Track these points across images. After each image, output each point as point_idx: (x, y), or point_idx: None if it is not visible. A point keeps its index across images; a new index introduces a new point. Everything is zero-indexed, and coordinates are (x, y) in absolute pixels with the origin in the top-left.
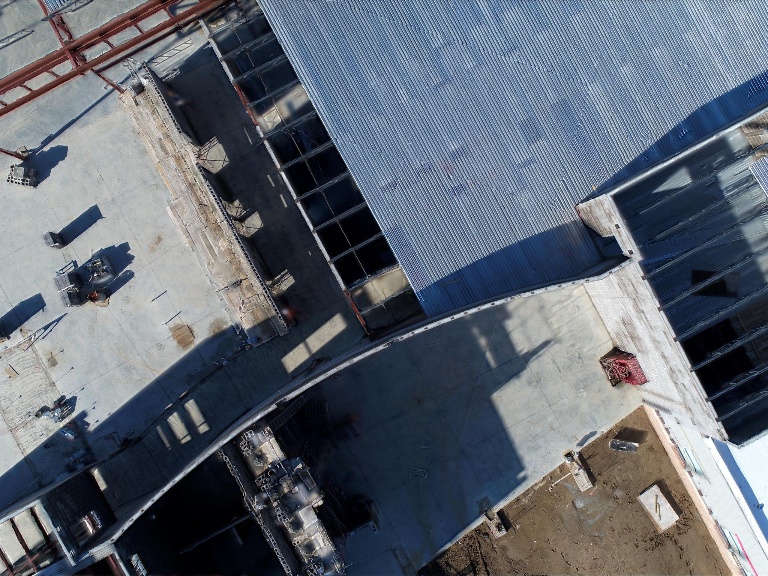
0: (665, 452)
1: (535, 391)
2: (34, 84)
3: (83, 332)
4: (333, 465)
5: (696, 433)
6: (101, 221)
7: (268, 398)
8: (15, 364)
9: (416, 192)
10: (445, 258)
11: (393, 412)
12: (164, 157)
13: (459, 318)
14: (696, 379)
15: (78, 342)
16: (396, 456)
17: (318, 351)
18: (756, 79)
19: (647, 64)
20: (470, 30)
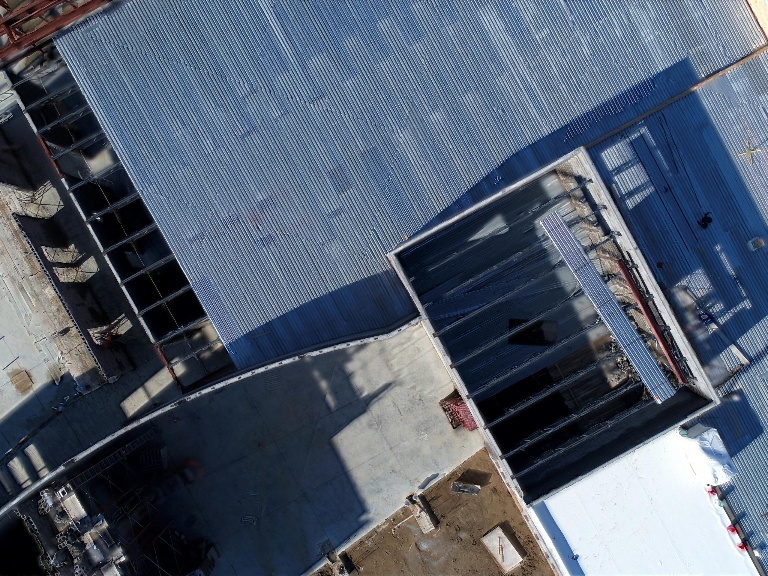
0: (509, 494)
1: (376, 434)
2: None
3: None
4: (174, 509)
5: (511, 484)
6: None
7: None
8: None
9: (224, 244)
10: (254, 310)
11: (233, 456)
12: None
13: (298, 361)
14: (490, 436)
15: None
16: (237, 499)
17: (156, 395)
18: (573, 124)
19: (460, 110)
20: (277, 78)
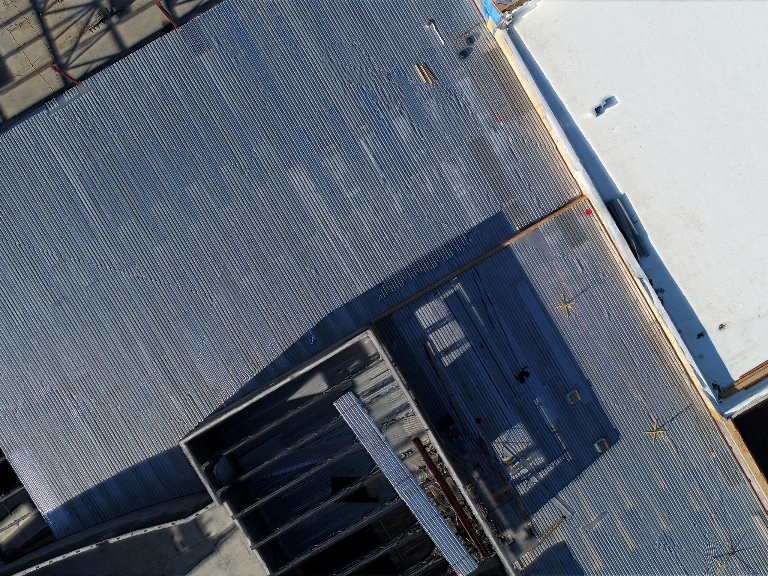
0: None
1: (225, 573)
2: None
3: None
4: None
5: None
6: None
7: None
8: None
9: (38, 414)
10: (71, 479)
11: None
12: None
13: None
14: None
15: None
16: None
17: (3, 542)
18: (387, 281)
19: (273, 272)
20: (86, 246)
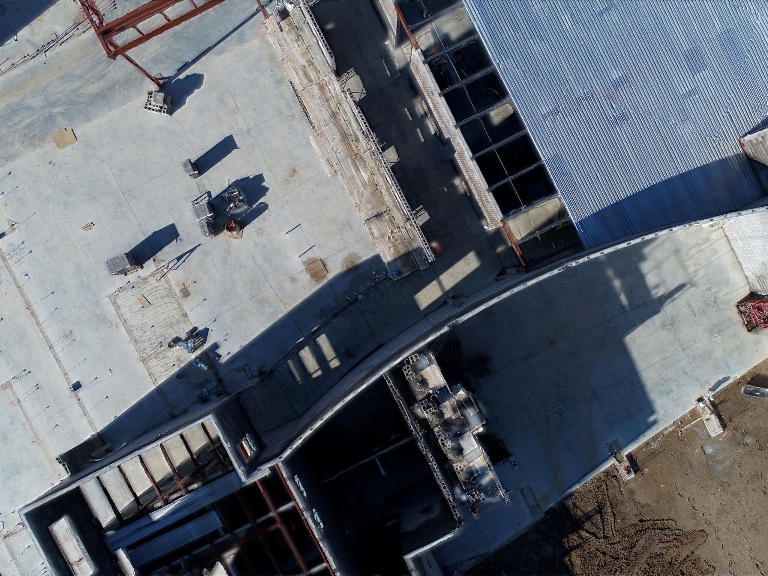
0: None
1: (669, 334)
2: (171, 10)
3: (216, 264)
4: None
5: None
6: (236, 152)
7: (409, 331)
8: (148, 294)
9: (578, 120)
10: (605, 189)
11: (525, 352)
12: (308, 85)
13: (595, 259)
14: None
15: (211, 273)
16: (526, 396)
17: (451, 288)
18: None
19: None
20: None
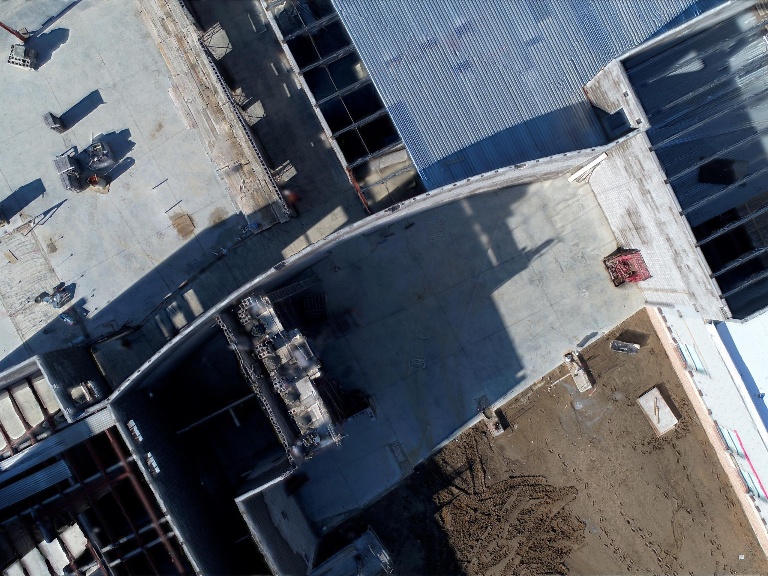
0: (666, 355)
1: (537, 290)
2: None
3: (83, 219)
4: (331, 359)
5: (699, 321)
6: (102, 107)
7: None
8: (14, 249)
9: (421, 68)
10: (449, 136)
11: (393, 307)
12: (166, 37)
13: (462, 214)
14: (701, 255)
15: (78, 229)
16: (395, 352)
17: None
18: None
19: None
20: None
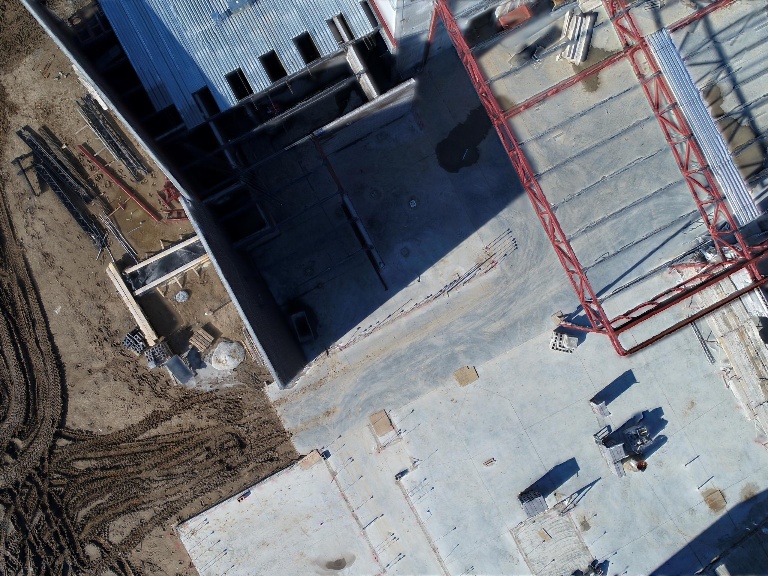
0: None
1: None
2: None
3: (616, 496)
4: None
5: None
6: (635, 386)
7: None
8: (548, 528)
9: None
10: None
11: None
12: (727, 331)
13: None
14: None
15: (611, 506)
16: None
17: None
18: None
19: None
20: None
